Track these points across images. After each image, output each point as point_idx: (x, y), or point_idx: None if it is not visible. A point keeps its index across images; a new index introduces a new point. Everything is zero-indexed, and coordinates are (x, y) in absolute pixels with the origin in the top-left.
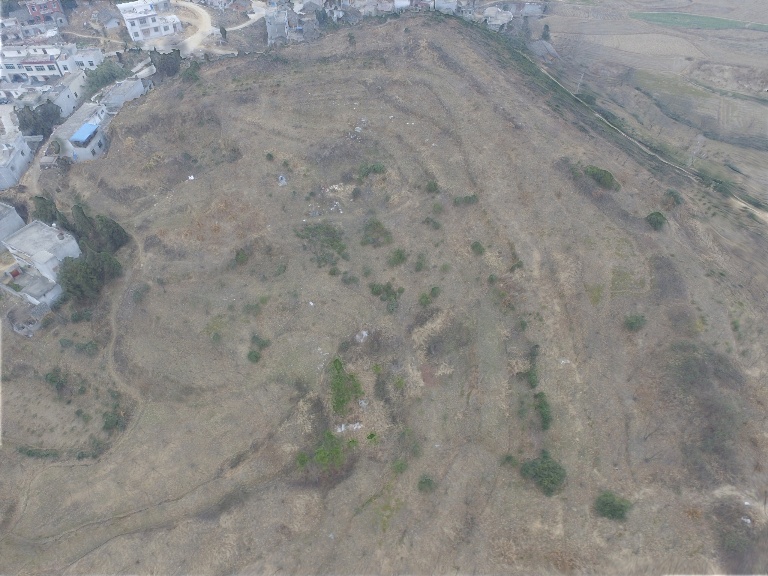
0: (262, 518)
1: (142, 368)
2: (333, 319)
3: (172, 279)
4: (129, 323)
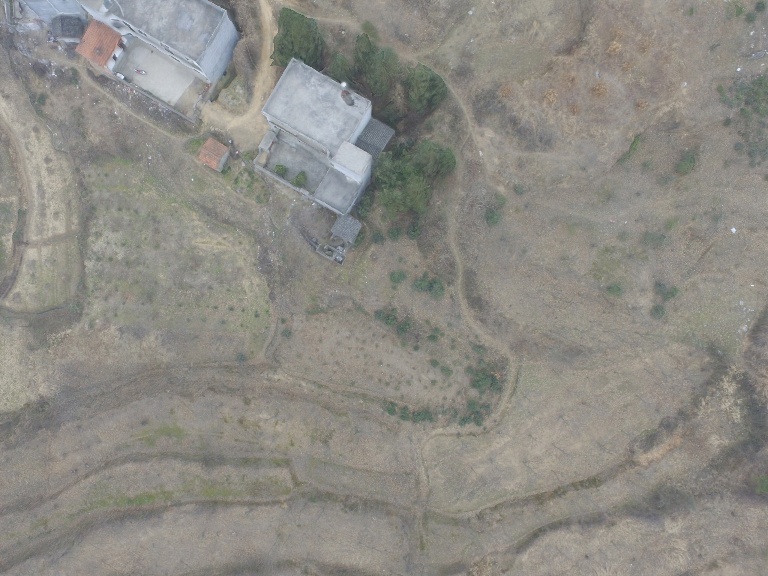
0: (711, 528)
1: (509, 319)
2: (765, 259)
3: (536, 186)
4: (481, 255)
